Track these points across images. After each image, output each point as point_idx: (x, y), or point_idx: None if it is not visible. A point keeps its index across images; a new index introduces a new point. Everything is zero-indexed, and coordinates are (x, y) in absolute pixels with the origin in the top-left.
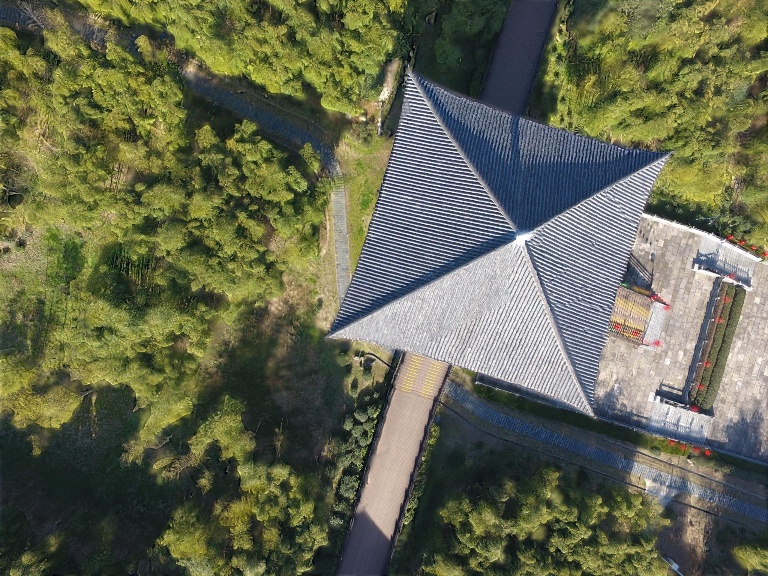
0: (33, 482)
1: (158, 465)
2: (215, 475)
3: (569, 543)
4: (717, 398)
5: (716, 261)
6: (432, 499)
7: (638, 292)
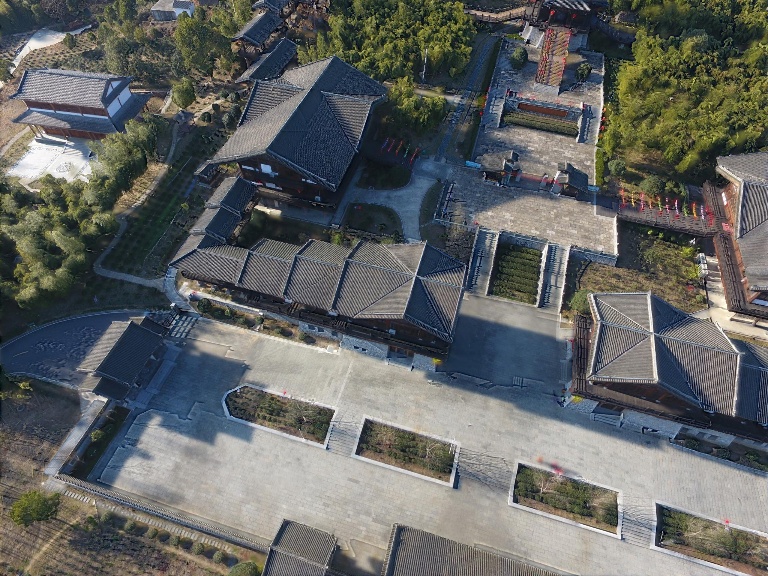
0: None
1: None
2: None
3: None
4: (509, 129)
5: (589, 117)
6: None
7: (561, 87)
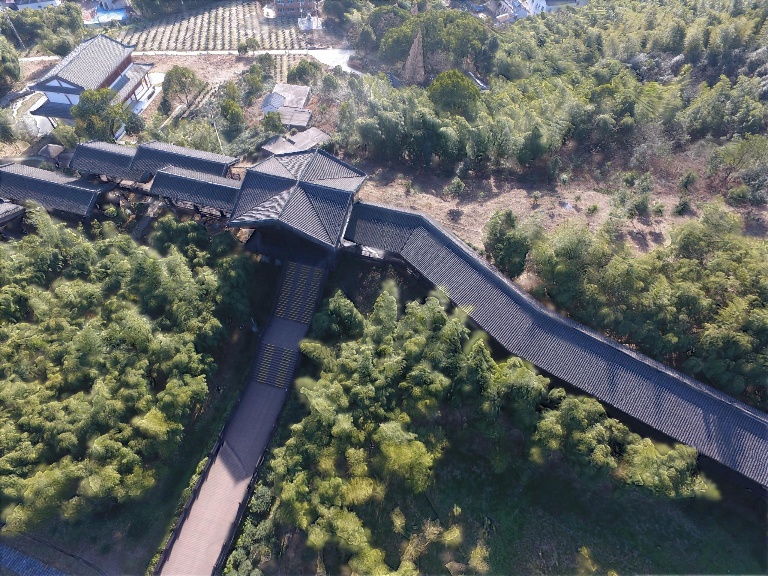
0: (588, 496)
1: (455, 533)
2: (406, 508)
3: (19, 452)
4: None
5: None
6: (176, 483)
7: None
